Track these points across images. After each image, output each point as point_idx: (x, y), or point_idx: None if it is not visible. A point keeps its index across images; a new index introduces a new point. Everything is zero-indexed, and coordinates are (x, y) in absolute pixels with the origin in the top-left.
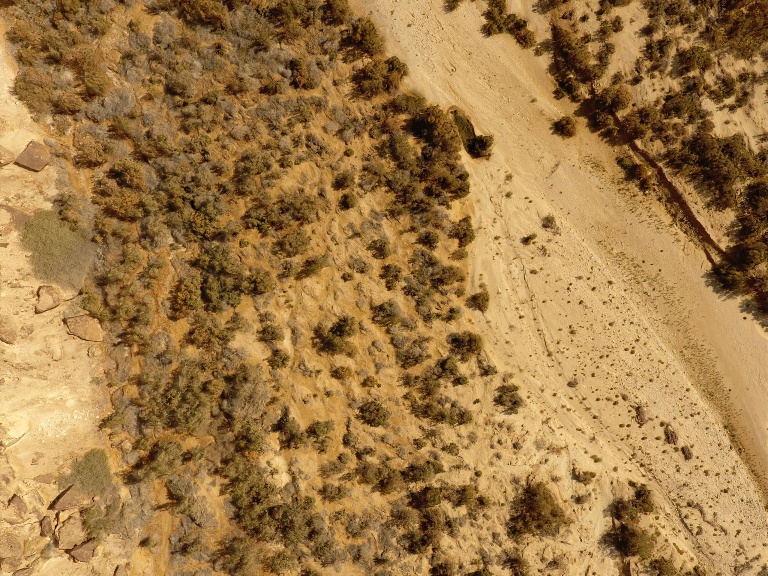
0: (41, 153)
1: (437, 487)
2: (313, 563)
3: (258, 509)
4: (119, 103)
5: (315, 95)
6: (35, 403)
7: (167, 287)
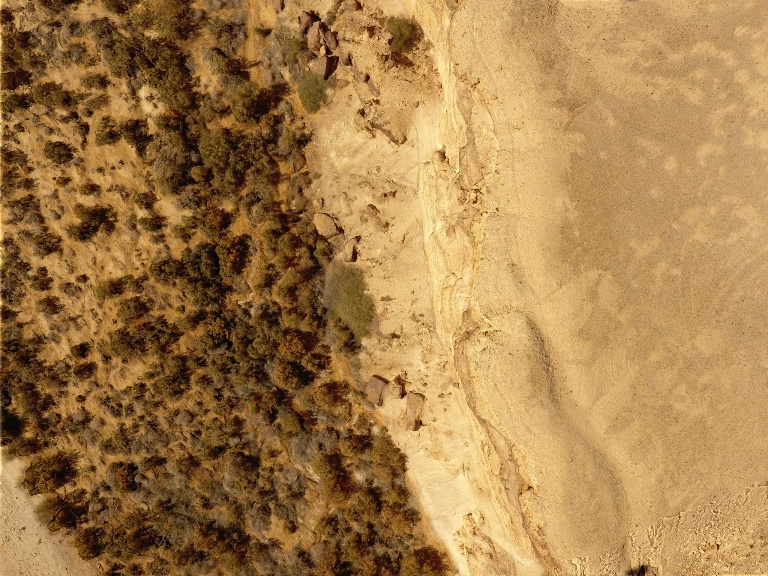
0: (372, 394)
1: (5, 90)
2: (116, 21)
3: (158, 65)
4: (304, 447)
5: (112, 456)
6: (354, 152)
7: (254, 266)
